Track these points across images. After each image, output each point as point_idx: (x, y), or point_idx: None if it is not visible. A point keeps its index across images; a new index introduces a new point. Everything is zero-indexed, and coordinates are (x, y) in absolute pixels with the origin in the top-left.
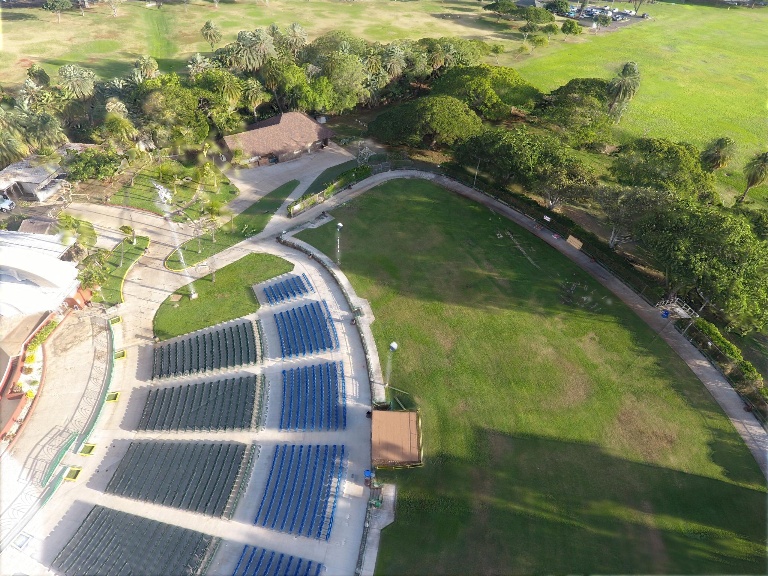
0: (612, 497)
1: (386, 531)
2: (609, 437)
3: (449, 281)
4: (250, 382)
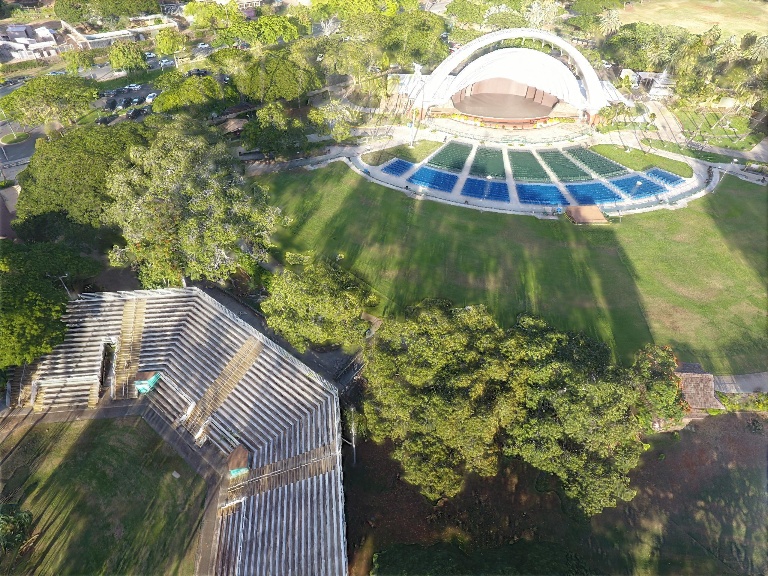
0: (605, 293)
1: (534, 217)
2: (653, 298)
3: (751, 240)
4: (585, 174)
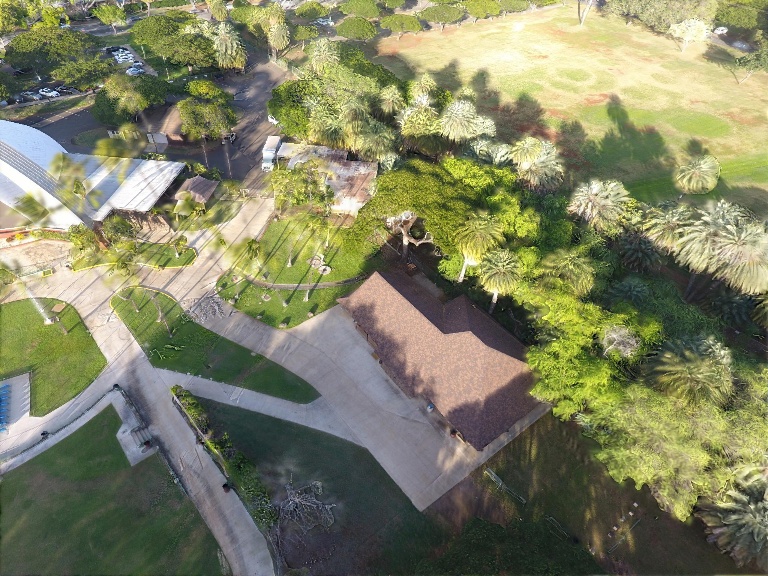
0: None
1: None
2: None
3: None
4: None
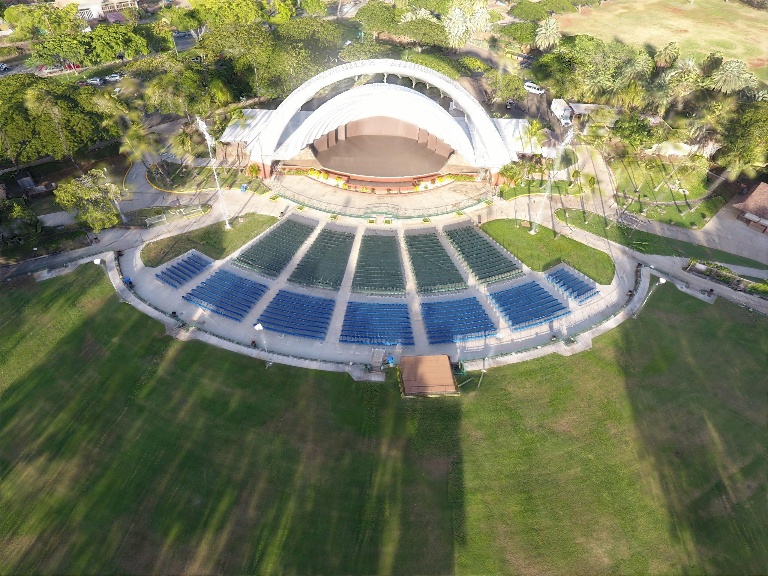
0: None
1: (347, 376)
2: None
3: (675, 430)
4: (457, 279)
